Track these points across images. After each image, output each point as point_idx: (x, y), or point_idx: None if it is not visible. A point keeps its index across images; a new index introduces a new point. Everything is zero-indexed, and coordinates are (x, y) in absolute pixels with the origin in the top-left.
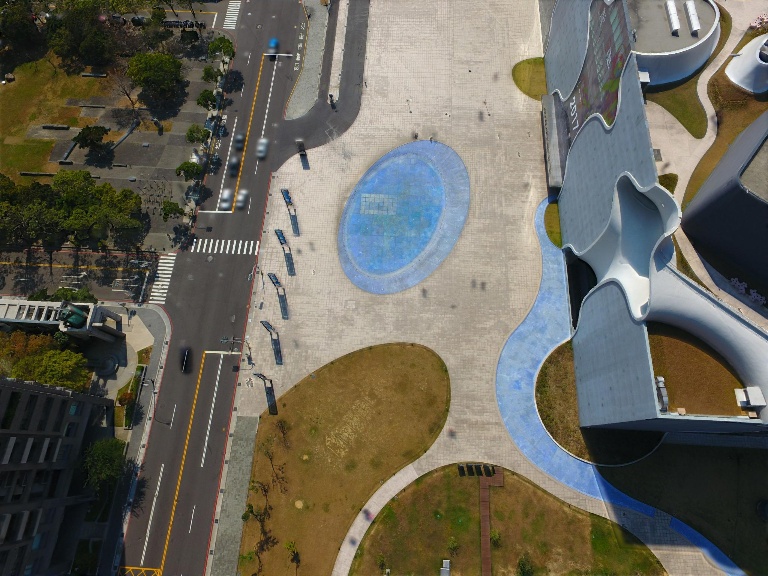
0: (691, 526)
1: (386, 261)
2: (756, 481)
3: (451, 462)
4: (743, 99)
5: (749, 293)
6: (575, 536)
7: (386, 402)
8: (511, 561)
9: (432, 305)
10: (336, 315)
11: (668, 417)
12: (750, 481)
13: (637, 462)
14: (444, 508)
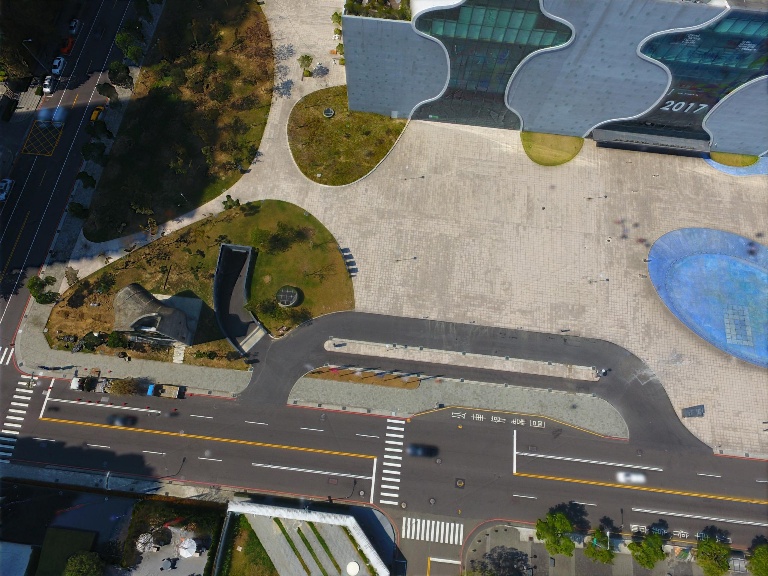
0: None
1: None
2: None
3: None
4: None
5: None
6: None
7: None
8: None
9: None
10: None
11: None
12: None
13: None
14: None
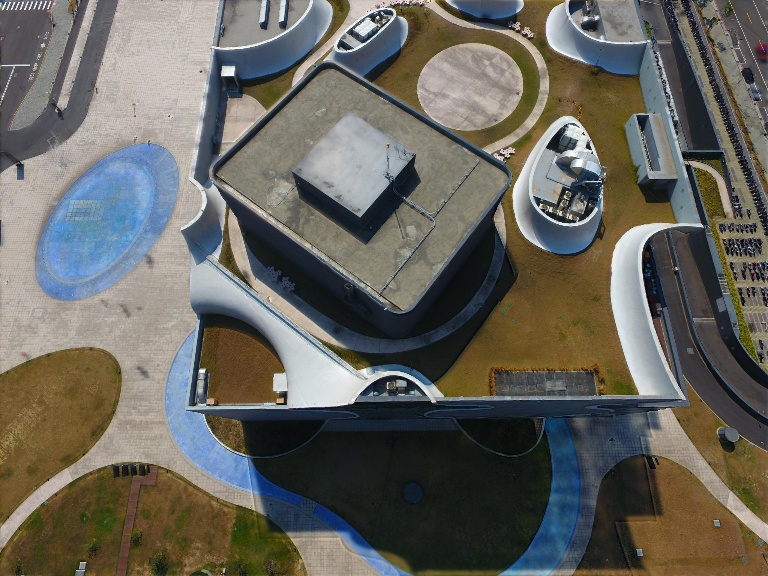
0: (335, 512)
1: (82, 267)
2: (407, 463)
3: (107, 464)
4: None
5: (281, 281)
6: (217, 529)
7: (53, 408)
8: (148, 559)
9: (118, 308)
10: (21, 324)
11: (195, 408)
12: (401, 464)
13: (292, 452)
14: (91, 510)
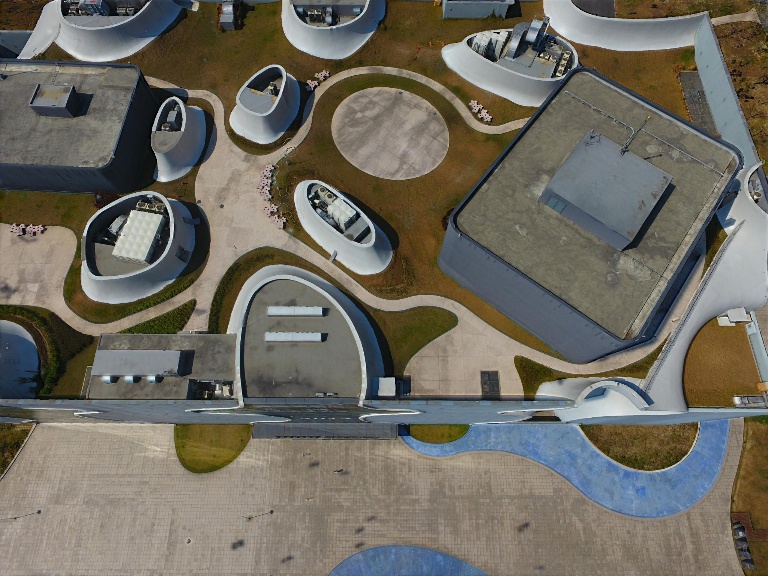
0: None
1: None
2: None
3: (743, 575)
4: (401, 262)
5: None
6: None
7: None
8: None
9: None
10: None
11: None
12: None
13: None
14: None
